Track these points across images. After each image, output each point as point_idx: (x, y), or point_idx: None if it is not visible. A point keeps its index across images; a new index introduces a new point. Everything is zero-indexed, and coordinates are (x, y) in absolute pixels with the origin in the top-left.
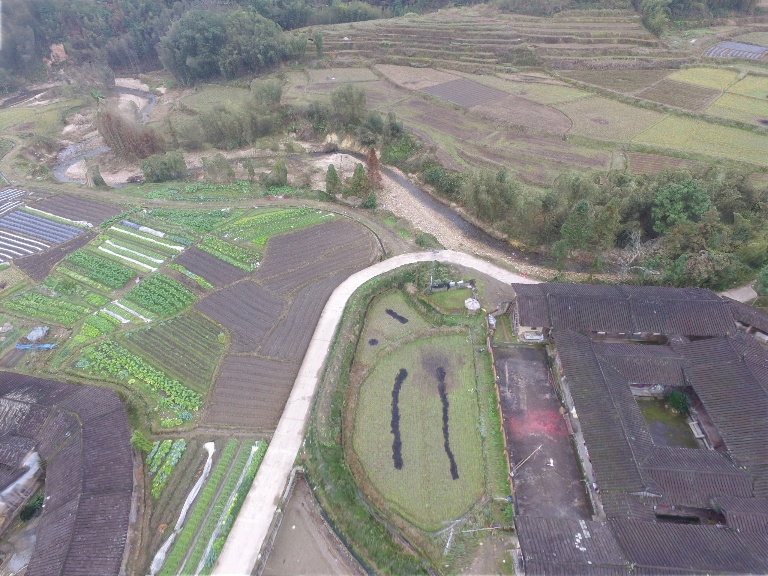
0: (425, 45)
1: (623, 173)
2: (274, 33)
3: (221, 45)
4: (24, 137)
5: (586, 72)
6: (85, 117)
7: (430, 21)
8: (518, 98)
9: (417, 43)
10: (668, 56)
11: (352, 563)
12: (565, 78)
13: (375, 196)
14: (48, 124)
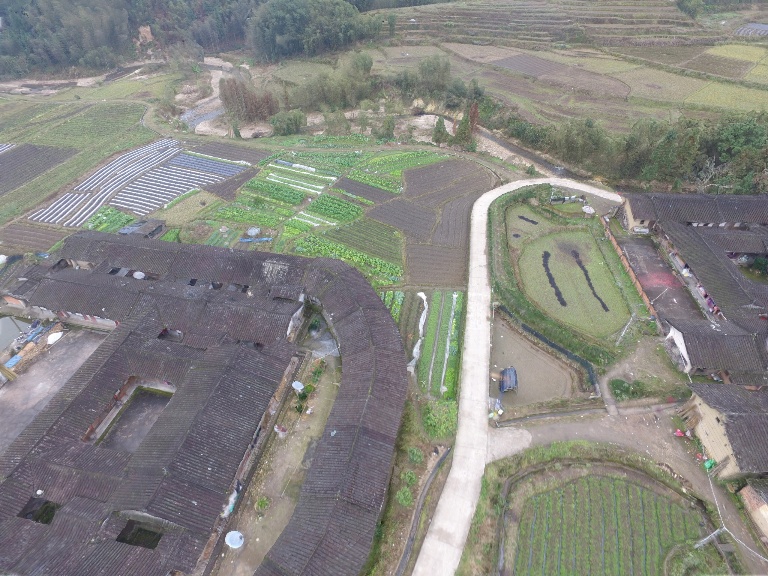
0: (485, 25)
1: None
2: (353, 14)
3: (305, 25)
4: (152, 101)
5: (632, 48)
6: (191, 87)
7: (487, 4)
8: (577, 69)
9: (478, 24)
10: (703, 35)
11: (551, 353)
12: (615, 53)
13: None
14: (162, 93)
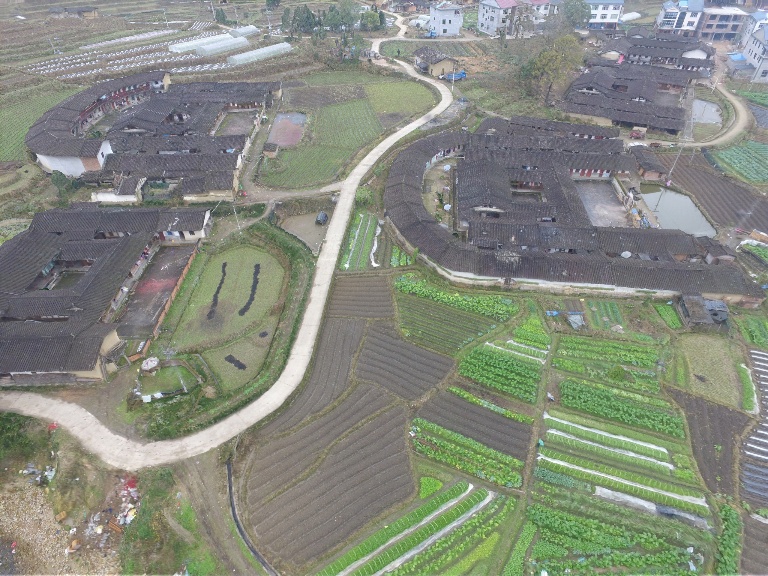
0: None
1: None
2: None
3: None
4: None
5: None
6: None
7: None
8: None
9: None
10: None
11: None
12: None
13: None
14: None
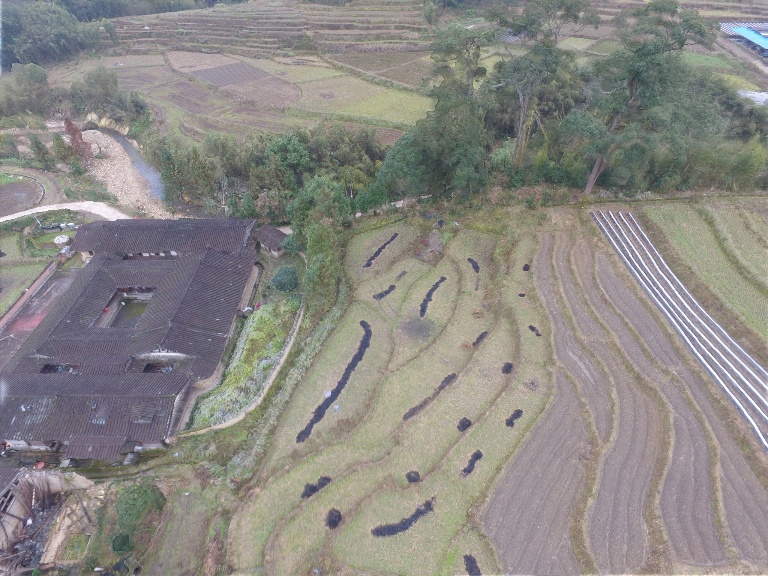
0: (217, 33)
1: (262, 133)
2: (65, 22)
3: (17, 34)
4: None
5: (355, 55)
6: None
7: (229, 11)
8: (274, 78)
9: (210, 31)
10: None
11: None
12: (330, 60)
13: (91, 164)
14: None
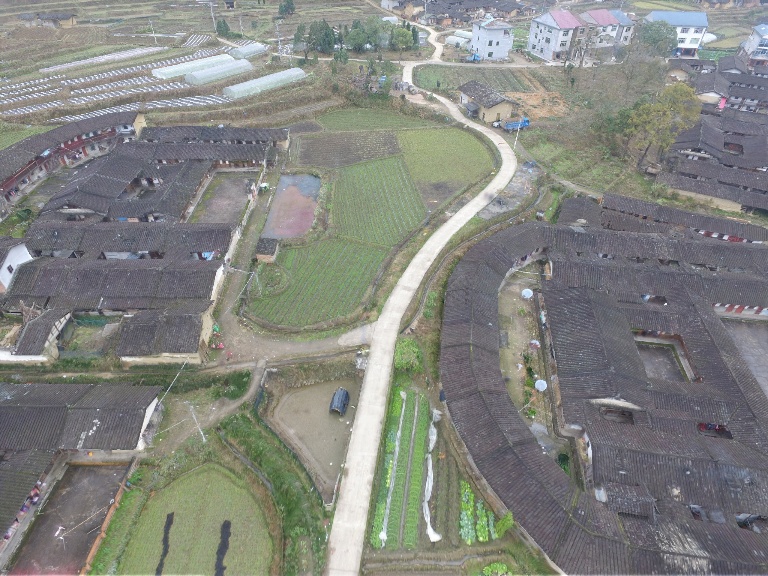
0: None
1: None
2: None
3: None
4: None
5: None
6: None
7: None
8: None
9: None
10: None
11: None
12: None
13: None
14: None
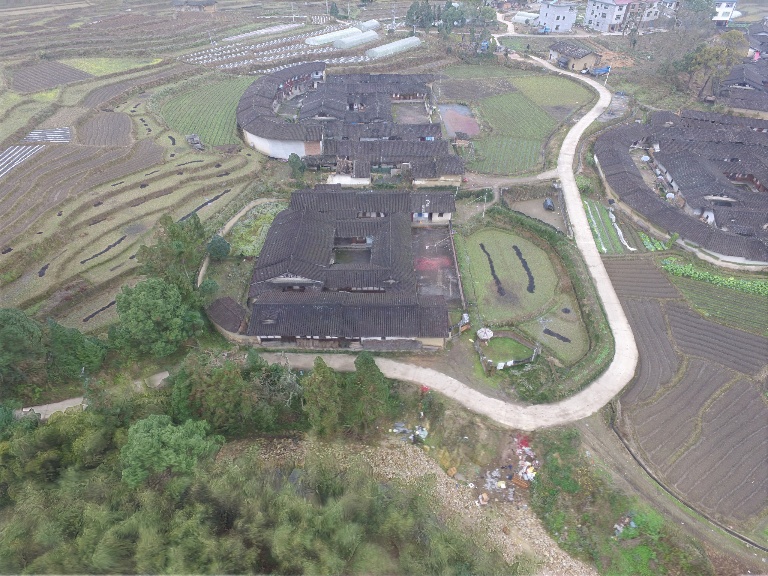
0: None
1: (204, 545)
2: None
3: None
4: None
5: None
6: None
7: None
8: None
9: None
10: None
11: None
12: None
13: None
14: None
